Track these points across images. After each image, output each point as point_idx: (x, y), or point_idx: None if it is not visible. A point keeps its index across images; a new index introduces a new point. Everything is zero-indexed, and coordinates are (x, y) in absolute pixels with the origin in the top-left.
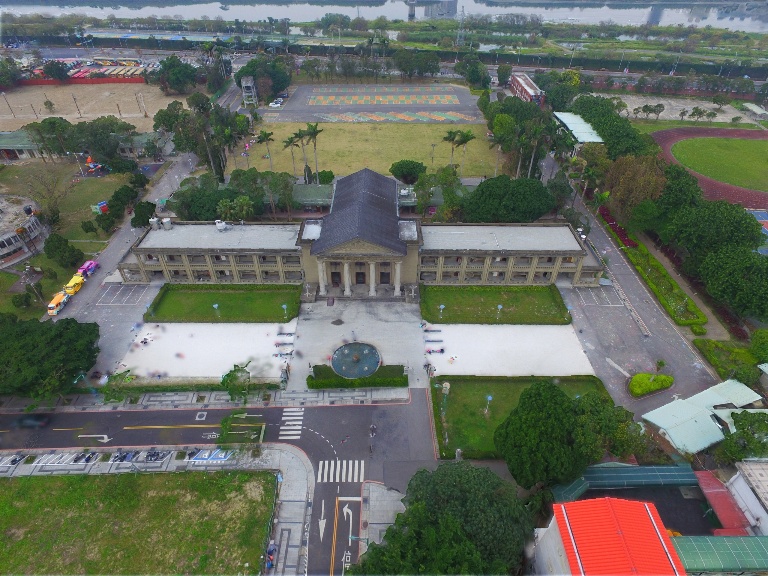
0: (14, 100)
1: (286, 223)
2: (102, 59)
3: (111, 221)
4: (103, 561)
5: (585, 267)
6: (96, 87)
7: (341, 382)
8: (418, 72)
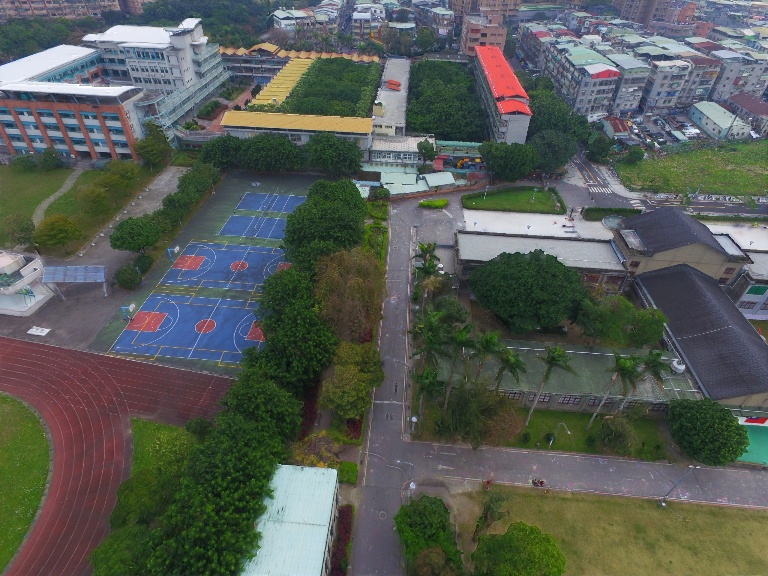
0: None
1: None
2: None
3: None
4: None
5: (450, 246)
6: None
7: (622, 208)
8: None
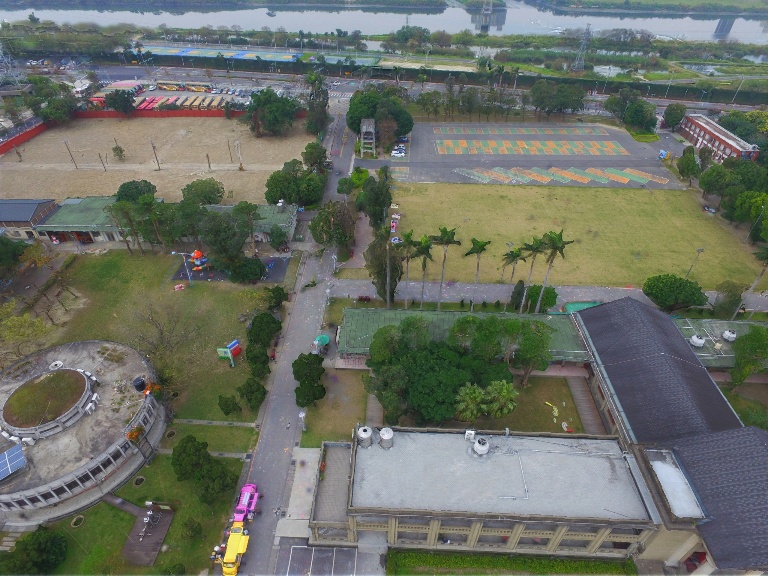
0: (72, 140)
1: (582, 436)
2: (167, 83)
3: (262, 393)
4: None
5: None
6: (167, 122)
7: None
8: (558, 108)
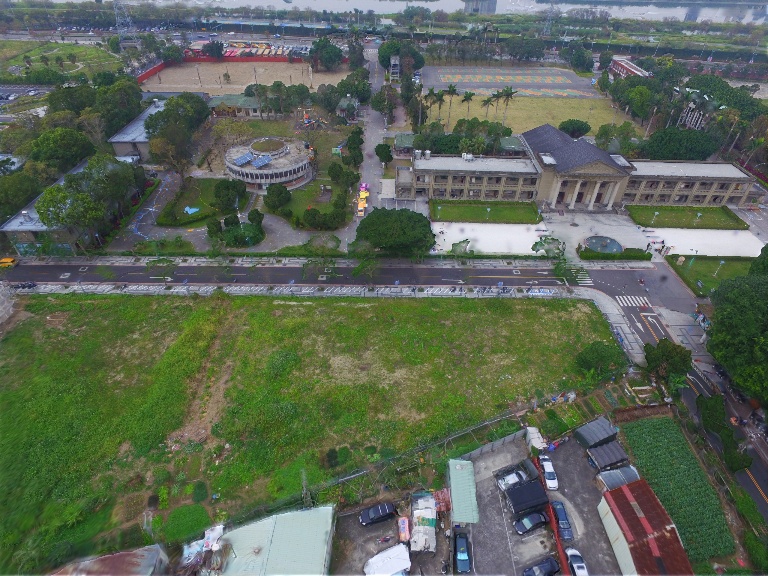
0: (187, 73)
1: (514, 157)
2: (237, 42)
3: (362, 157)
4: (514, 336)
5: (751, 192)
6: (248, 64)
7: (607, 254)
8: (526, 57)
